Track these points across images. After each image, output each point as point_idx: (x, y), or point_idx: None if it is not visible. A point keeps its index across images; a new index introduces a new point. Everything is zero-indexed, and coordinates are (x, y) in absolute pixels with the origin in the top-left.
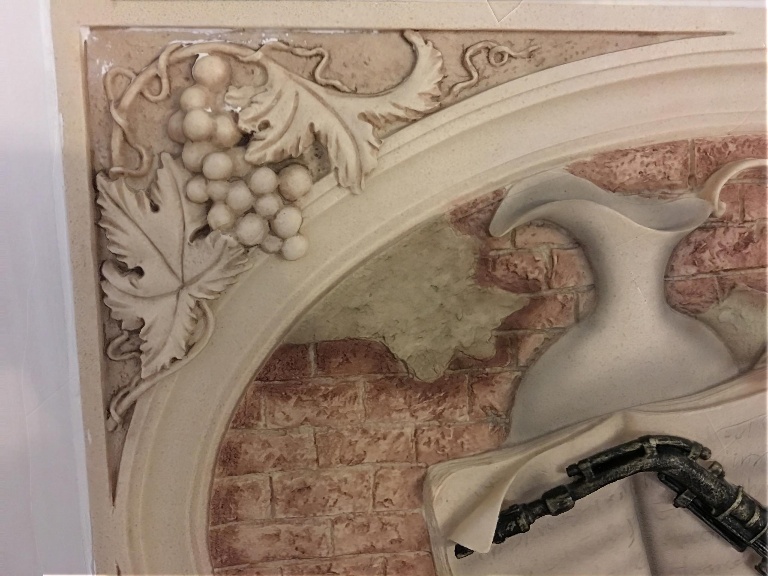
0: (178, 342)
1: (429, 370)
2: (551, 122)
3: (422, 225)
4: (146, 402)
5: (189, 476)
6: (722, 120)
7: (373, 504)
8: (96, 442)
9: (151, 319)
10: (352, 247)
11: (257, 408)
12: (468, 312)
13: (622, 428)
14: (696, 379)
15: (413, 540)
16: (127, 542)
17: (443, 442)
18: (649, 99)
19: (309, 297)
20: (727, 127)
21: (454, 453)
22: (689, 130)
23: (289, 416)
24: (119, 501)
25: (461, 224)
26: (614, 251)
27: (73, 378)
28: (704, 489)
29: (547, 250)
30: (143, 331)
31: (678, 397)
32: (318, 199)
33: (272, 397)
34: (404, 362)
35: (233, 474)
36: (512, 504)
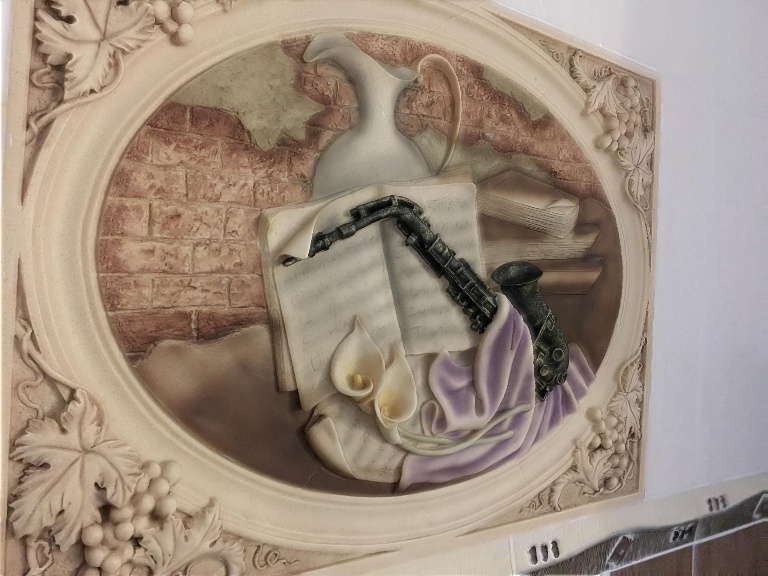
0: (97, 77)
1: (265, 141)
2: (336, 5)
3: (265, 43)
4: (64, 121)
5: (85, 195)
6: (418, 31)
7: (224, 234)
8: (16, 146)
9: (79, 55)
10: (219, 48)
11: (147, 146)
12: (290, 107)
13: (376, 196)
14: (412, 172)
15: (250, 264)
16: (31, 237)
17: (272, 194)
18: (384, 9)
19: (189, 74)
20: (421, 36)
21: (278, 203)
22: (404, 31)
23: (170, 157)
24: (29, 200)
25: (287, 50)
26: (371, 85)
27: (2, 90)
28: (422, 230)
29: (333, 81)
30: (70, 63)
31: (404, 181)
32: (203, 6)
33: (159, 140)
34: (249, 134)
35: (123, 195)
36: (318, 232)
